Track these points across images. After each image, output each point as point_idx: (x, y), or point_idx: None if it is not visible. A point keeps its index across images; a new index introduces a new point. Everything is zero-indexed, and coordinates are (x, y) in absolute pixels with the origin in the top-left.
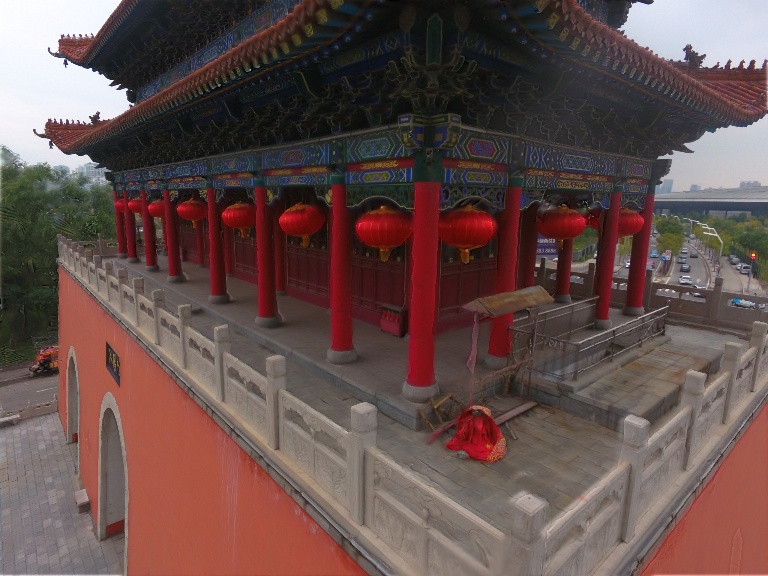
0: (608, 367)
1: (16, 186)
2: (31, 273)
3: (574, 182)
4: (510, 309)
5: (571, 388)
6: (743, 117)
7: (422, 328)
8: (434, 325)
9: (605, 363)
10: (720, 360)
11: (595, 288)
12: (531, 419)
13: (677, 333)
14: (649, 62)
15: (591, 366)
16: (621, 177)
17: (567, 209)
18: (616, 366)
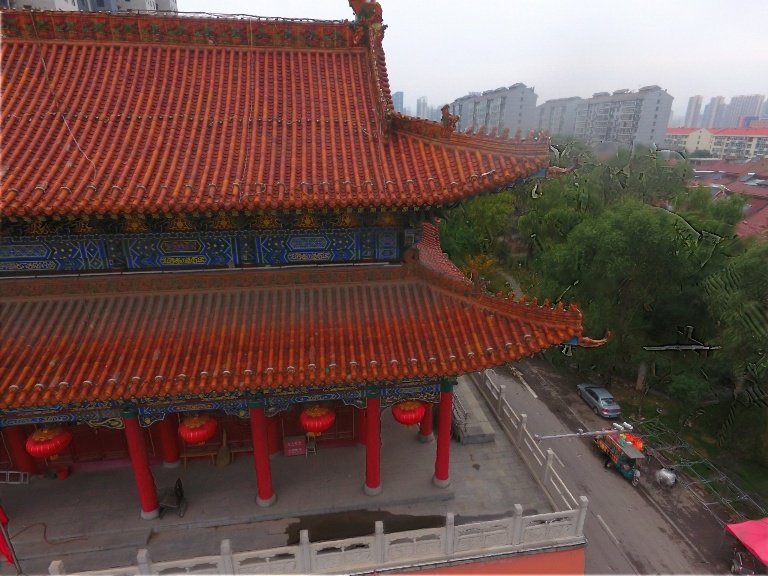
0: None
1: (759, 249)
2: (702, 356)
3: None
4: None
5: None
6: None
7: None
8: None
9: None
10: None
11: None
12: None
13: None
14: None
15: None
16: None
17: None
18: None
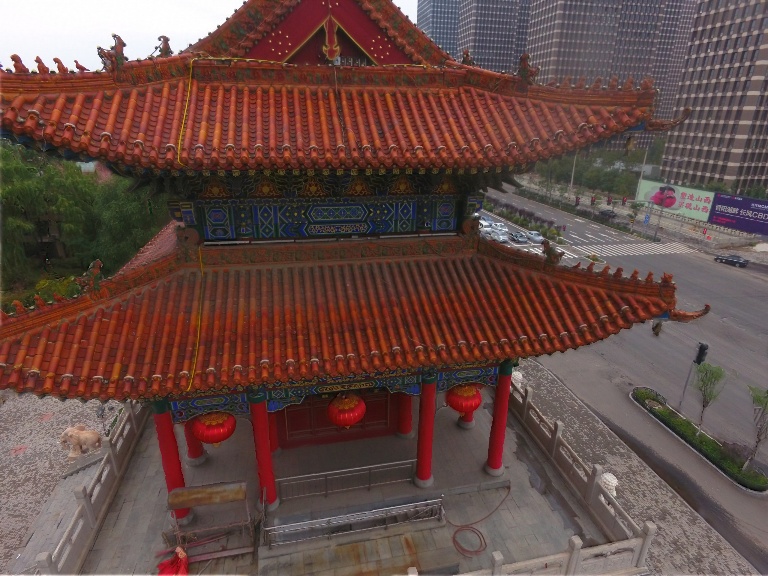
0: (317, 544)
1: None
2: None
3: (347, 385)
4: (186, 505)
5: (258, 555)
6: (535, 353)
7: (168, 487)
8: (283, 443)
9: (319, 539)
10: (455, 568)
11: (417, 451)
12: (230, 563)
13: (514, 508)
14: (257, 381)
15: (292, 542)
16: (428, 372)
17: (344, 402)
18: (328, 545)
